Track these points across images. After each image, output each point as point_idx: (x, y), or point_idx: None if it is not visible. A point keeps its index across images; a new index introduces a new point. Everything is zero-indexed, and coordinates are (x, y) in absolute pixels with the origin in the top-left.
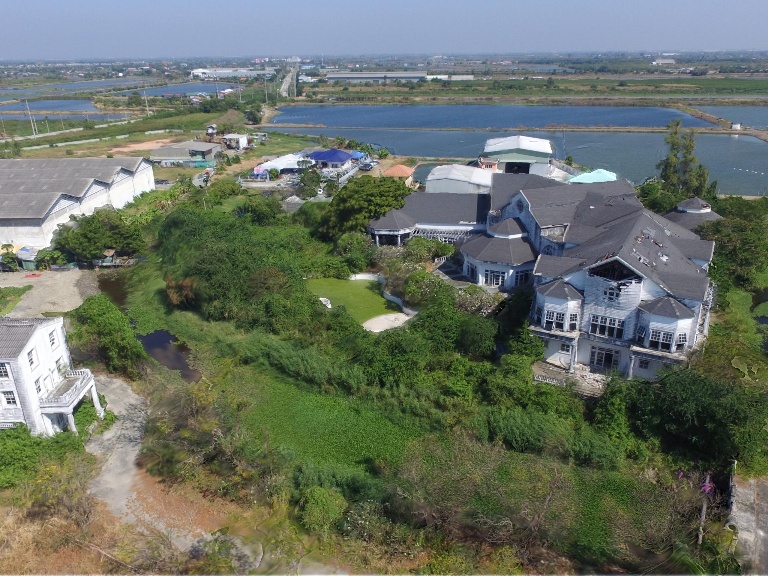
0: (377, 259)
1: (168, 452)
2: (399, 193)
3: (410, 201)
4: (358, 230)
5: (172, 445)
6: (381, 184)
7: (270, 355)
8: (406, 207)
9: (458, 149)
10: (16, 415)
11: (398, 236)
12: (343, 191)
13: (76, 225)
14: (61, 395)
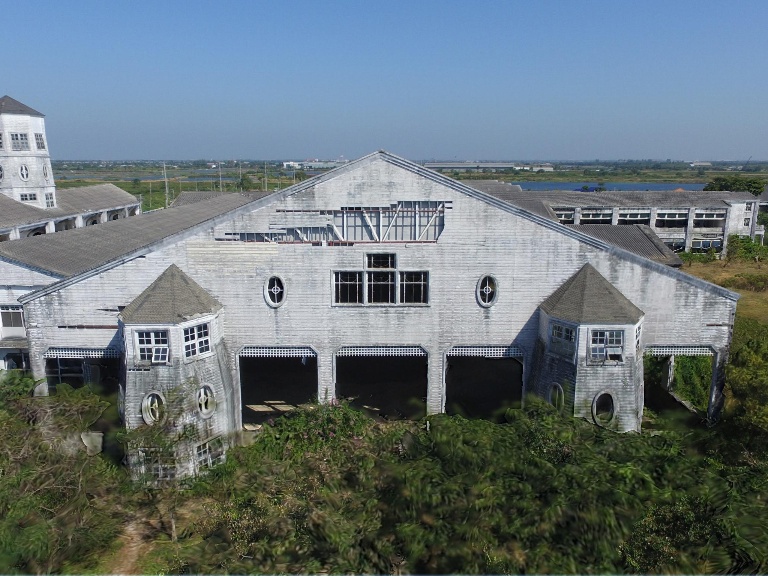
0: None
1: None
2: None
3: (765, 189)
4: None
5: None
6: None
7: None
8: None
9: None
10: (747, 232)
11: None
12: (722, 182)
13: None
14: None
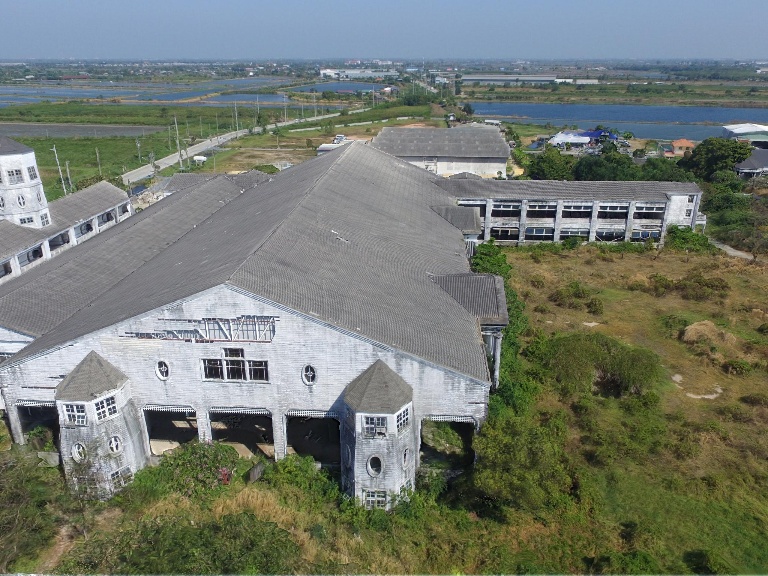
0: (751, 185)
1: (761, 241)
2: (749, 148)
3: (753, 153)
4: (728, 169)
5: (761, 239)
6: (734, 142)
7: (748, 219)
8: (752, 157)
9: (687, 134)
10: (688, 222)
11: (755, 173)
12: (709, 146)
13: (541, 161)
14: (704, 215)
